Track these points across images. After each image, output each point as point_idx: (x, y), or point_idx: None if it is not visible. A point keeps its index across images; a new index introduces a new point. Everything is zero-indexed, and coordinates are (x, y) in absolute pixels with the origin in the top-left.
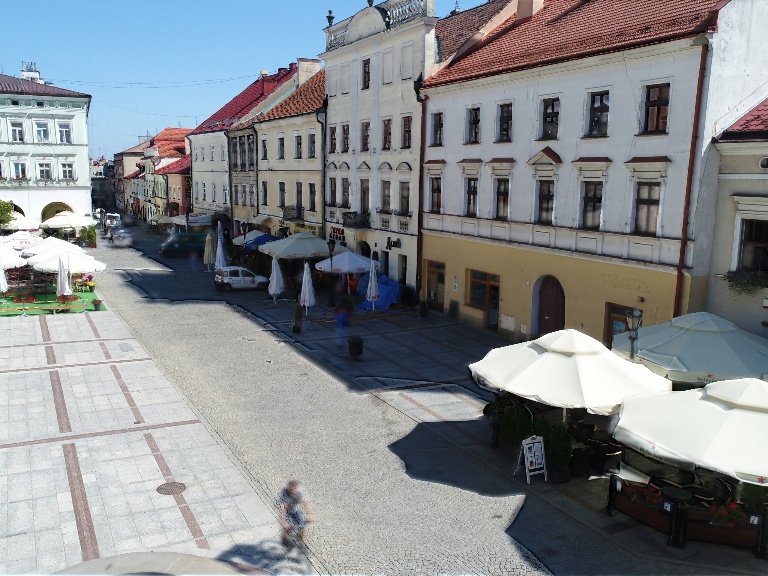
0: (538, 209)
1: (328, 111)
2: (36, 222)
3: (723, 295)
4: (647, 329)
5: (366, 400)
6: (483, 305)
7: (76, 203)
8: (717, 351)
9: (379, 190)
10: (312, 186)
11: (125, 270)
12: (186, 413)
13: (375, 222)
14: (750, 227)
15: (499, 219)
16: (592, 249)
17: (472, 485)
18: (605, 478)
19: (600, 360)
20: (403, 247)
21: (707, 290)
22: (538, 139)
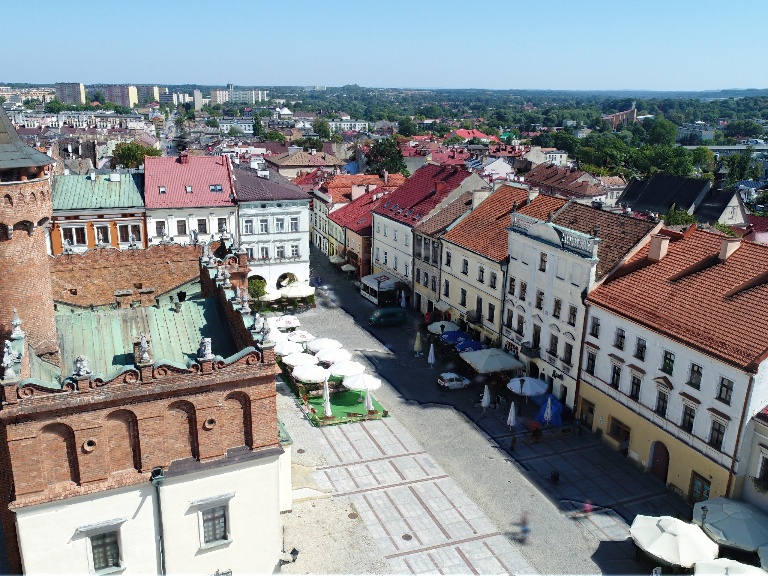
0: (658, 404)
1: (509, 266)
2: (277, 291)
3: (752, 487)
4: (711, 506)
5: (571, 521)
6: (618, 437)
7: (299, 272)
8: (741, 531)
9: (549, 338)
10: (491, 304)
11: (362, 352)
12: (492, 527)
13: (544, 356)
14: (767, 459)
15: (633, 399)
16: (687, 441)
17: None
18: None
19: (688, 539)
20: (565, 381)
21: (744, 482)
22: (661, 369)
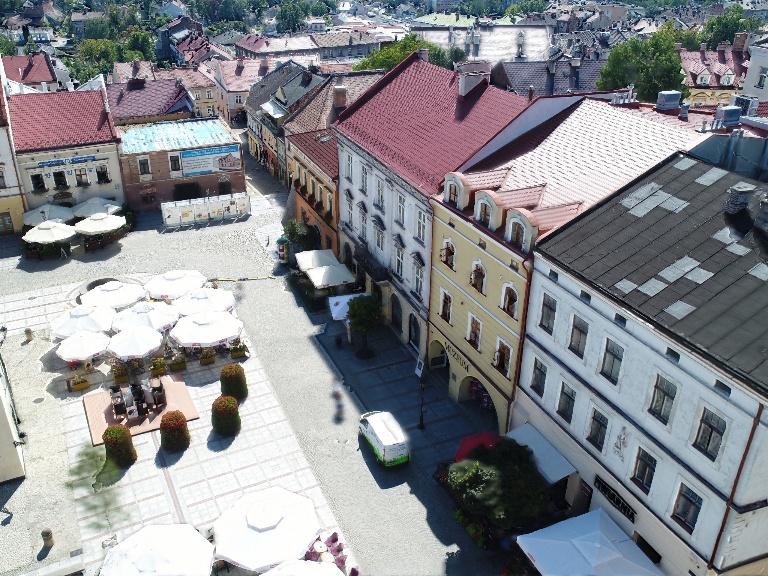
0: None
1: None
2: None
3: None
4: (35, 215)
5: None
6: None
7: None
8: (61, 213)
9: None
10: None
11: None
12: None
13: None
14: None
15: None
16: None
17: (62, 264)
18: (73, 250)
19: None
20: None
21: None
22: None
